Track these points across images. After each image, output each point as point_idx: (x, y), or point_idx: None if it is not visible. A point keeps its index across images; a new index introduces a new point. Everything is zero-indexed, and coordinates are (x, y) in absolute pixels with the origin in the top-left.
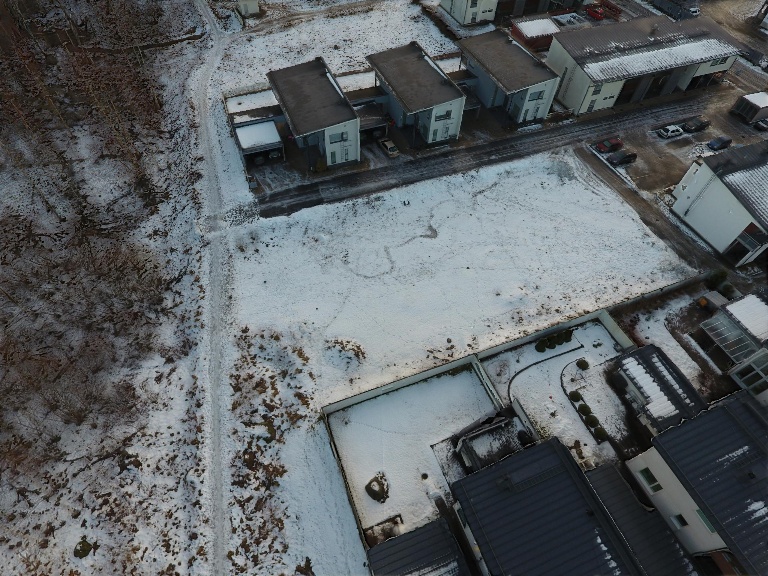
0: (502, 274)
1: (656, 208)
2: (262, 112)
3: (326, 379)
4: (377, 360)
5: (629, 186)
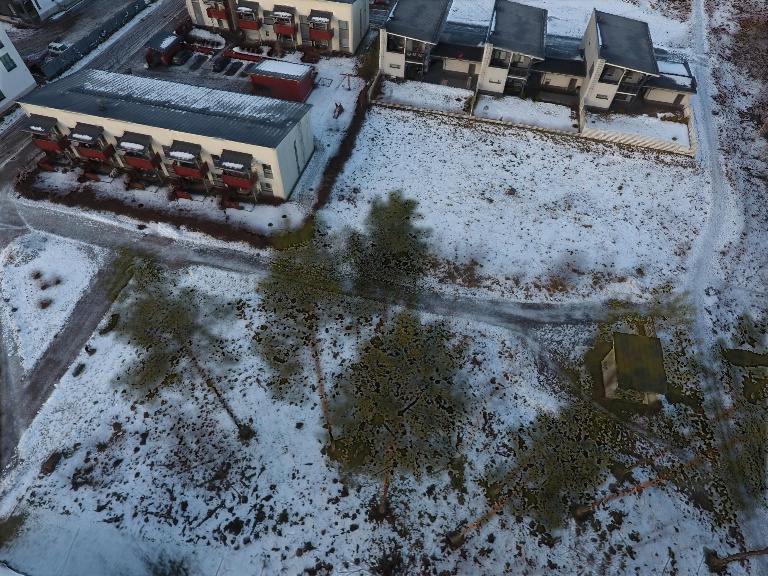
0: None
1: None
2: (662, 81)
3: None
4: None
5: None
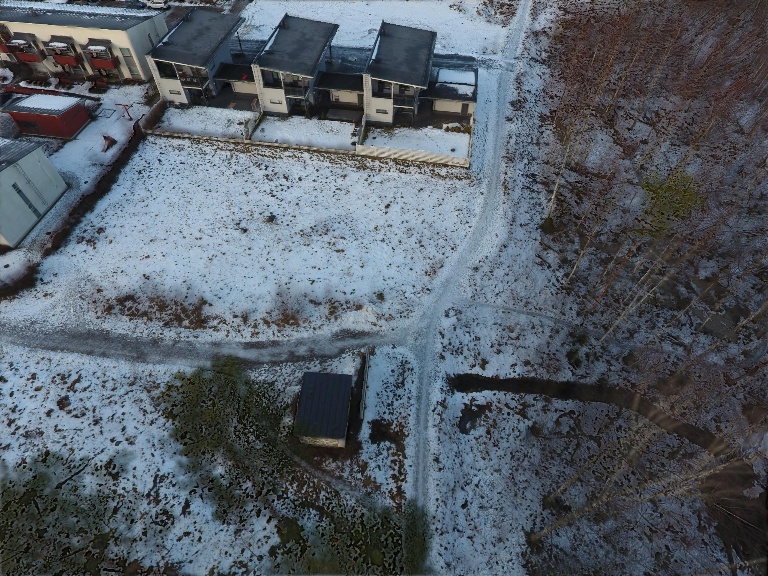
0: (356, 8)
1: (234, 3)
2: (444, 91)
3: (472, 6)
4: (445, 3)
5: (228, 13)
